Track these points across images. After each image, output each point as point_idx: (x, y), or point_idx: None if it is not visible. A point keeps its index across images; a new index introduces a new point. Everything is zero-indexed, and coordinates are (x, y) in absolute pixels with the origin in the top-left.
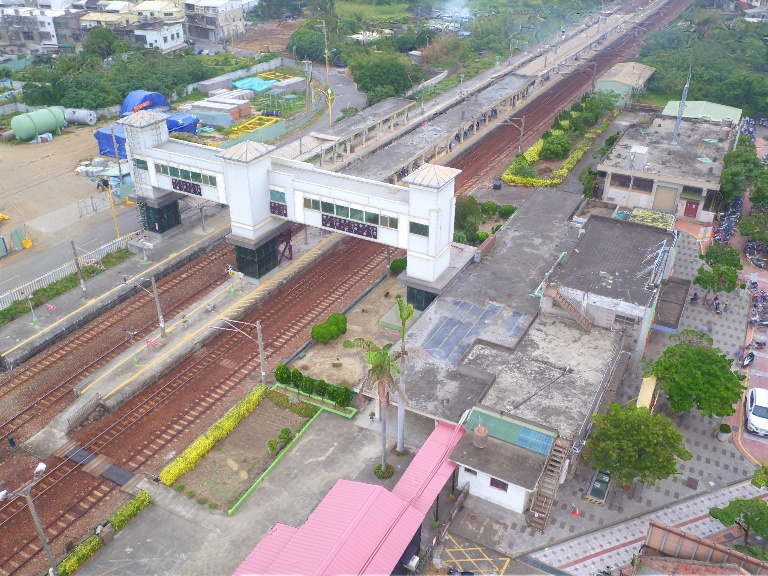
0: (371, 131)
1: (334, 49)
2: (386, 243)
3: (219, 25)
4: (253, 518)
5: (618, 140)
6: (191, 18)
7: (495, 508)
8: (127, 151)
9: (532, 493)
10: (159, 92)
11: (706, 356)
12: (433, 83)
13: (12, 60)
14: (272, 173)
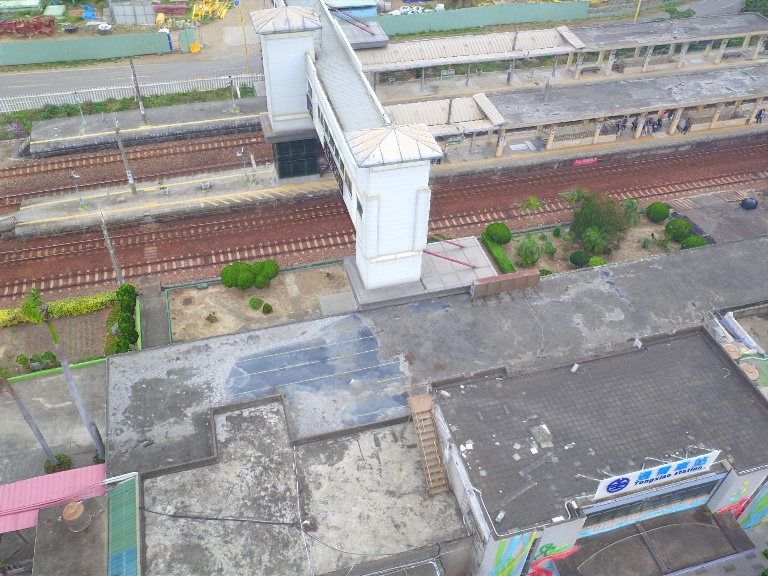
0: (690, 52)
1: None
2: (348, 208)
3: None
4: None
5: None
6: None
7: None
8: None
9: None
10: None
11: None
12: None
13: None
14: None
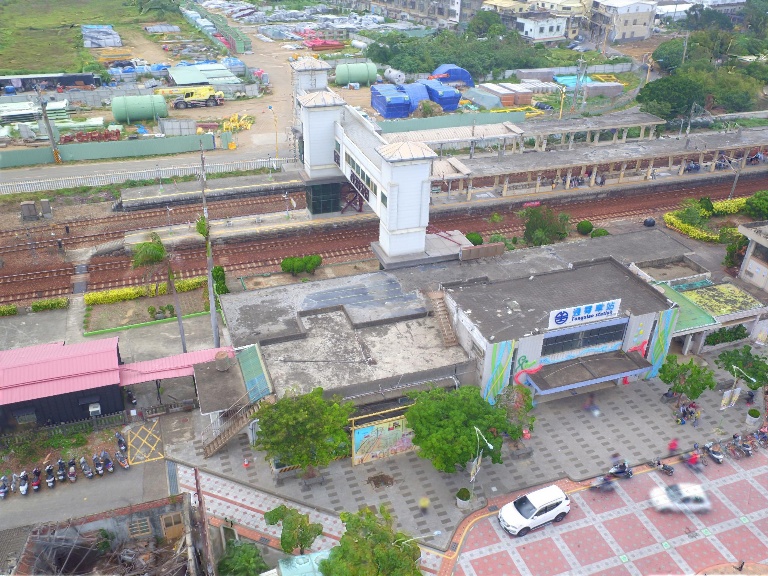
0: (602, 141)
1: (661, 59)
2: (372, 208)
3: None
4: None
5: None
6: (594, 16)
7: (206, 425)
8: (295, 90)
9: None
10: (472, 70)
11: None
12: (760, 116)
13: (421, 30)
14: (336, 125)
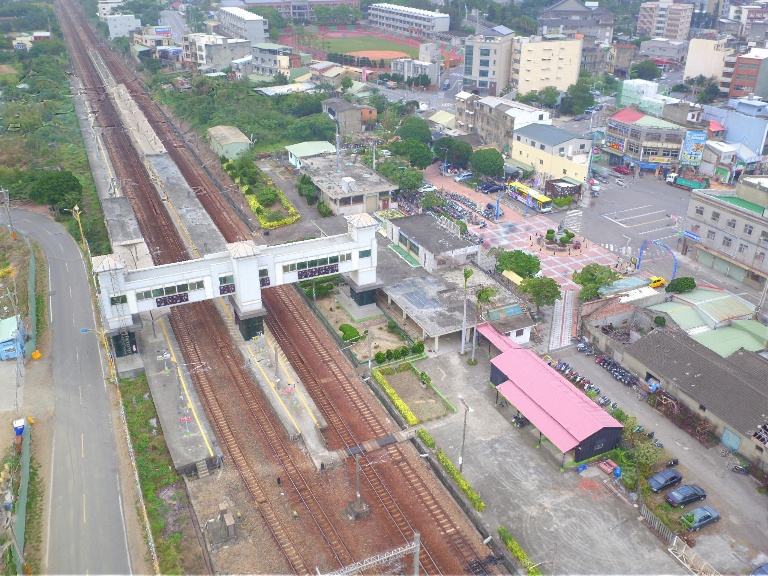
0: None
1: None
2: (344, 271)
3: None
4: None
5: (312, 179)
6: None
7: (521, 346)
8: (103, 294)
9: (533, 328)
10: None
11: (518, 252)
12: None
13: None
14: None
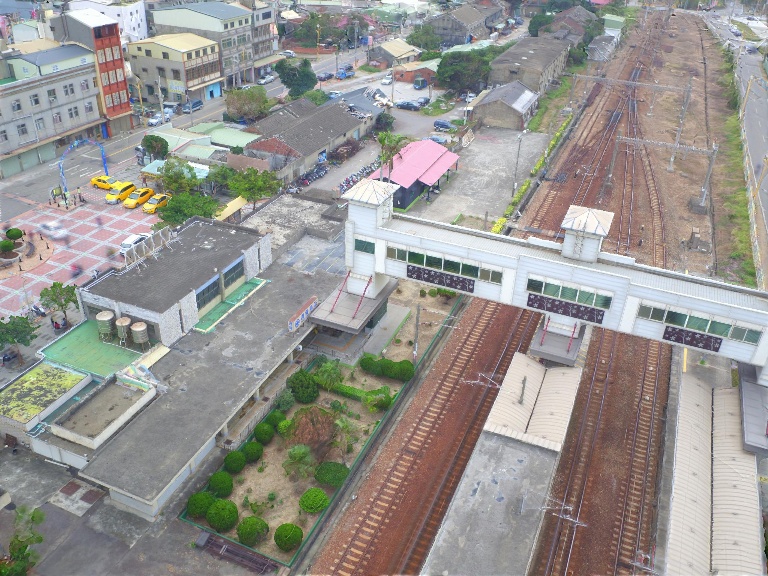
0: None
1: None
2: None
3: None
4: (449, 213)
5: None
6: None
7: None
8: None
9: None
10: None
11: None
12: None
13: None
14: (558, 245)
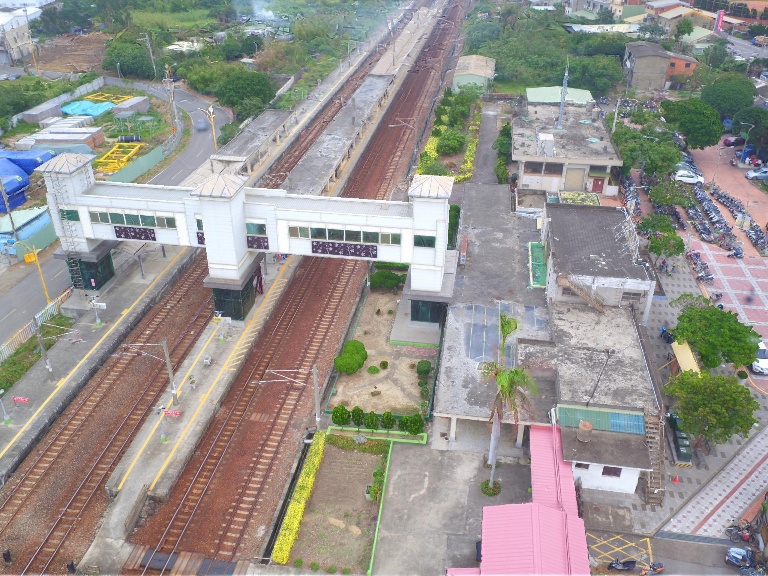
0: None
1: (174, 63)
2: (387, 260)
3: (9, 45)
4: (395, 572)
5: (512, 130)
6: None
7: (609, 495)
8: (49, 202)
9: (646, 472)
10: None
11: (721, 315)
12: (285, 90)
13: None
14: (249, 205)
